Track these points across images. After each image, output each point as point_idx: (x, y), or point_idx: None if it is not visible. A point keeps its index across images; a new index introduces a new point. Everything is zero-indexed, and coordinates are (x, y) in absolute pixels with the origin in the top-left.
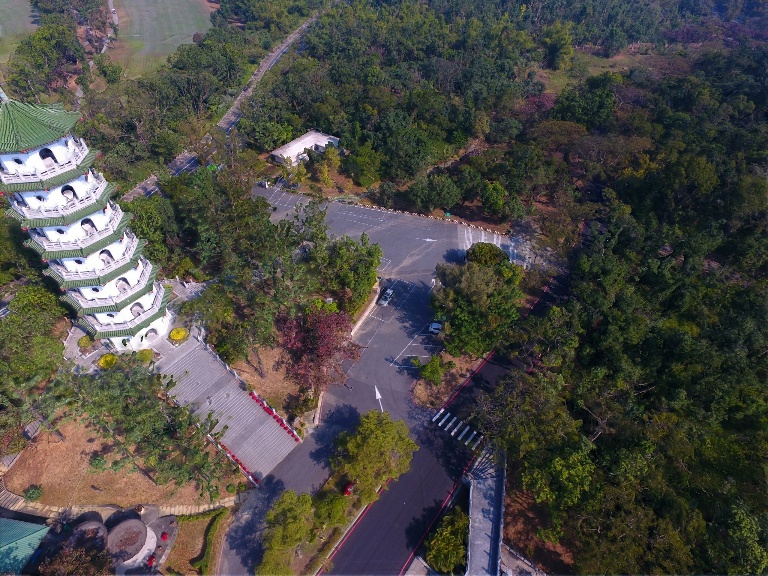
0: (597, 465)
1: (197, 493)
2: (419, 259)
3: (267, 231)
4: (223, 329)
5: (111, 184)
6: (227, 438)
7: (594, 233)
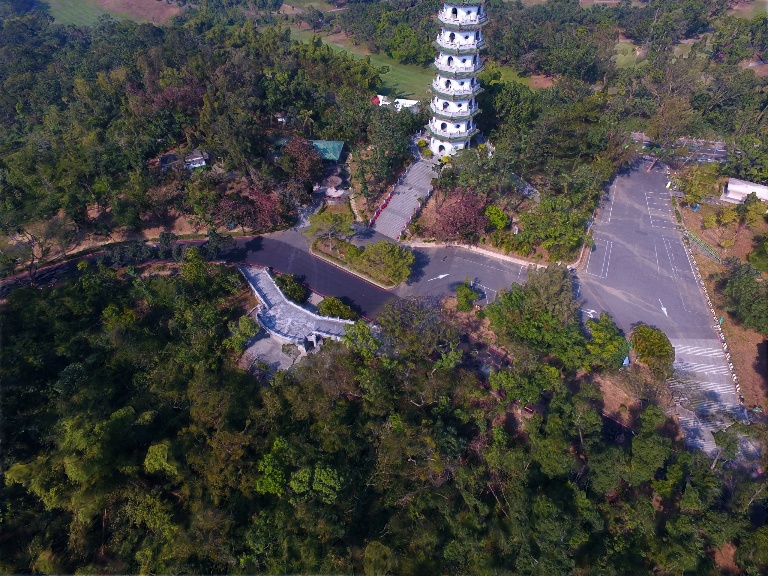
0: (373, 369)
1: (362, 205)
2: (622, 300)
3: None
4: None
5: (477, 49)
6: (391, 205)
7: (727, 430)
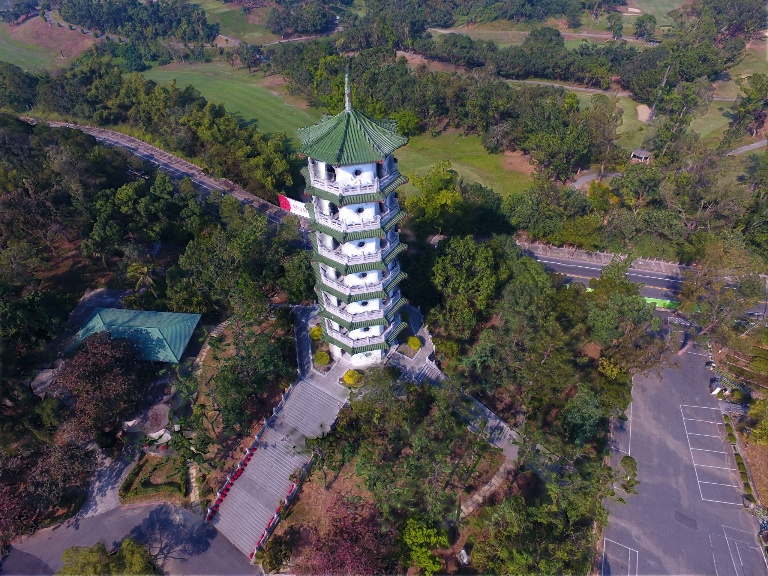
0: None
1: None
2: None
3: (577, 421)
4: (346, 419)
5: (381, 231)
6: (251, 471)
7: None
